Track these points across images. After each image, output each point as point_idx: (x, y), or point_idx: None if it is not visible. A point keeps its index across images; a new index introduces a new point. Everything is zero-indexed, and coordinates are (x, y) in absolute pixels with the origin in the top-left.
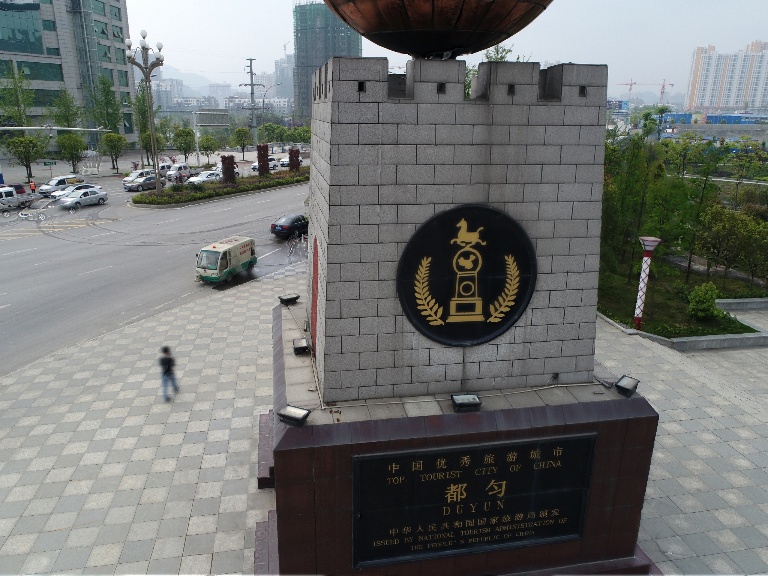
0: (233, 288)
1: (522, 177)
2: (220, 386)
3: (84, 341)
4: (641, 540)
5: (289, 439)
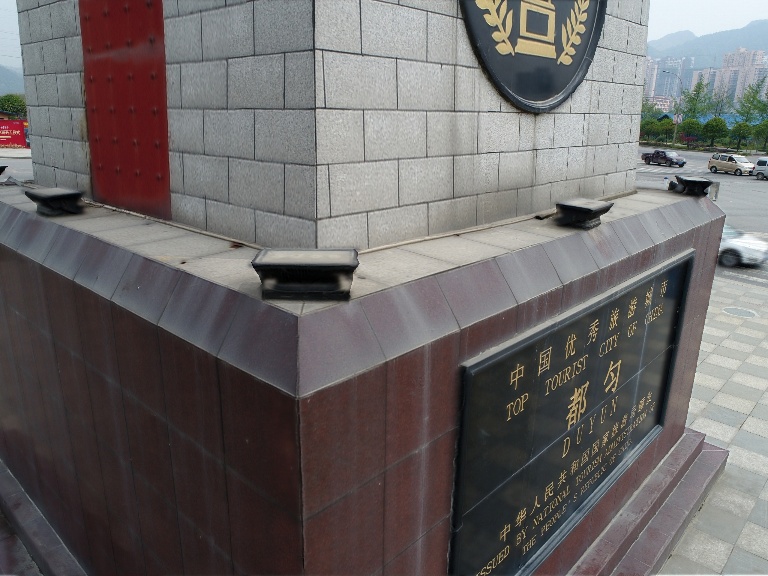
0: None
1: None
2: None
3: None
4: None
5: None
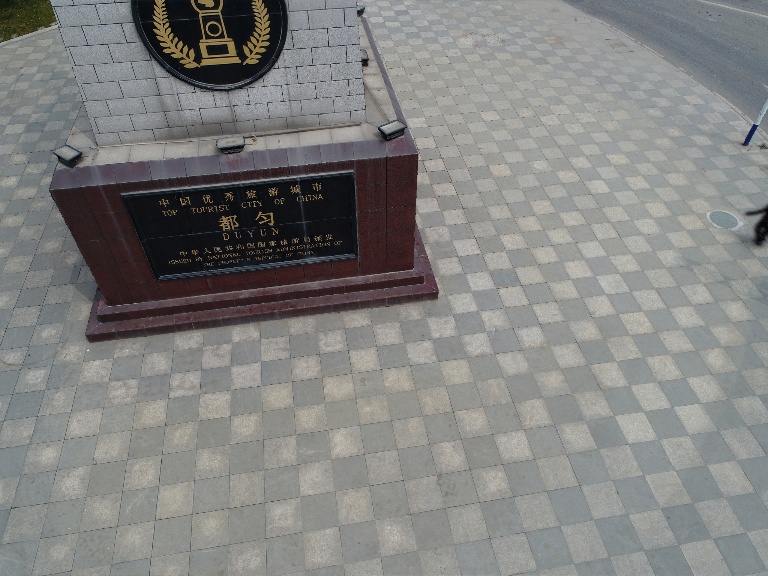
0: None
1: None
2: (533, 386)
3: None
4: None
5: None
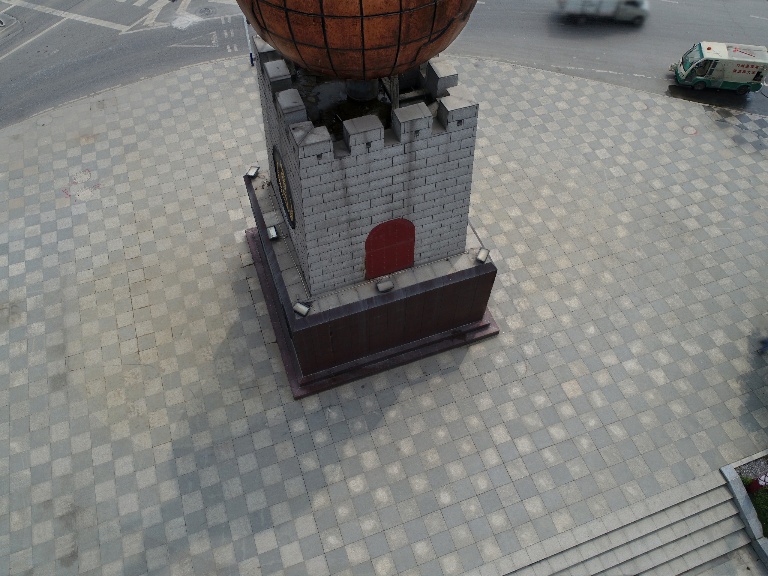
0: (672, 99)
1: (287, 165)
2: None
3: (513, 62)
4: (338, 397)
5: (246, 178)
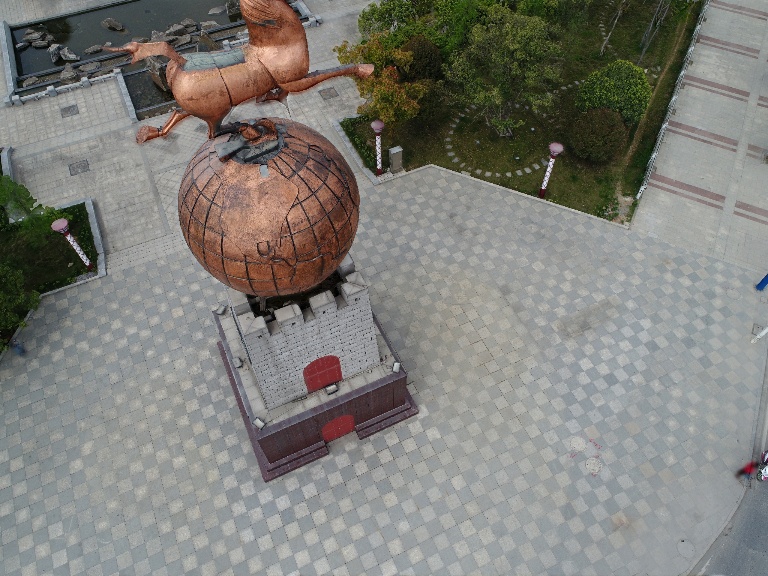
0: None
1: None
2: (216, 539)
3: None
4: None
5: None
